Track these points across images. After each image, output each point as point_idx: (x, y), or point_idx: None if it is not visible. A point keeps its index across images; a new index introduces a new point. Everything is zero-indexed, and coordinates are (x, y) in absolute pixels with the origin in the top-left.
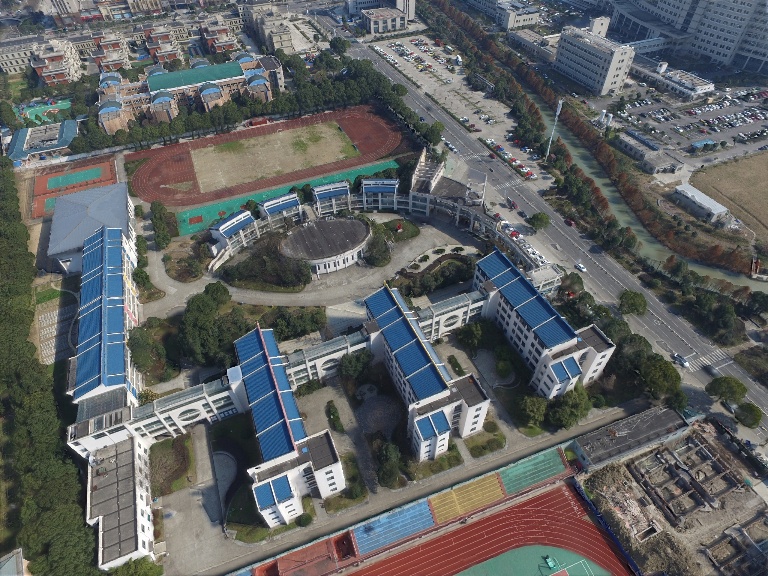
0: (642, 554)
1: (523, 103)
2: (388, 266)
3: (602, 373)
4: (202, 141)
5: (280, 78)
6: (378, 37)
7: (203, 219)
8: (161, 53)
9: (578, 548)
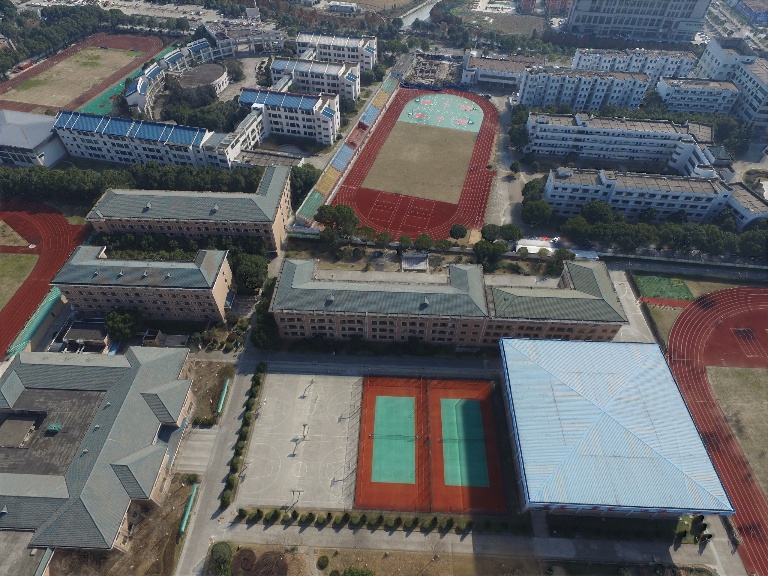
0: (435, 84)
1: None
2: (247, 77)
3: (377, 58)
4: None
5: None
6: None
7: (93, 113)
8: None
9: (420, 95)
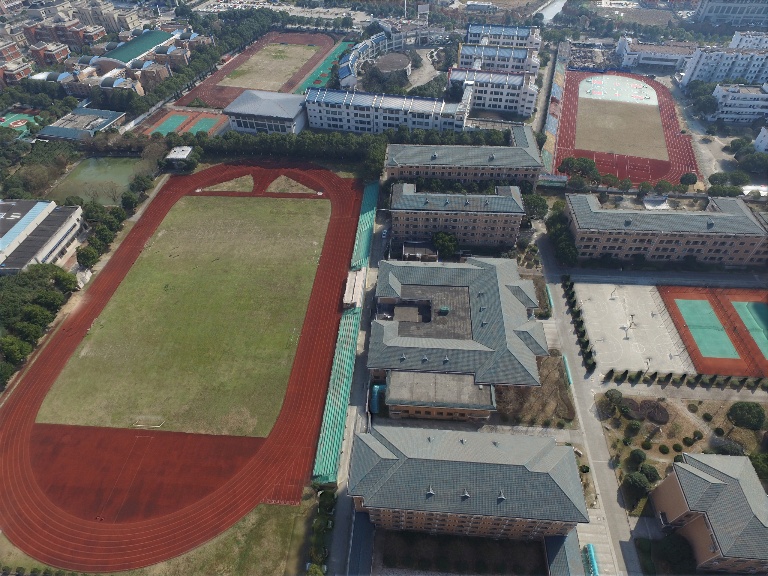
0: (600, 67)
1: (351, 3)
2: (424, 65)
3: None
4: (211, 79)
5: None
6: (191, 5)
7: None
8: (55, 50)
9: (588, 76)
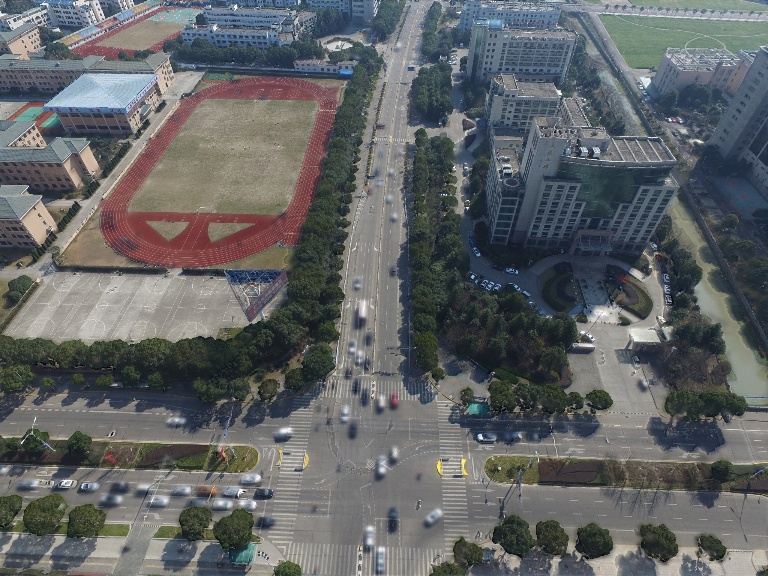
0: (186, 3)
1: None
2: None
3: None
4: None
5: None
6: None
7: None
8: None
9: None
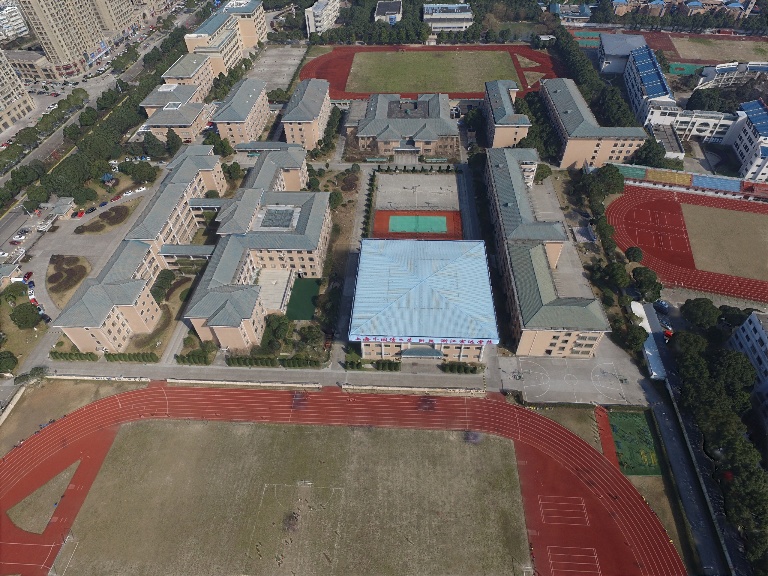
0: None
1: None
2: None
3: None
4: (678, 34)
5: (750, 8)
6: None
7: (685, 69)
8: None
9: None
